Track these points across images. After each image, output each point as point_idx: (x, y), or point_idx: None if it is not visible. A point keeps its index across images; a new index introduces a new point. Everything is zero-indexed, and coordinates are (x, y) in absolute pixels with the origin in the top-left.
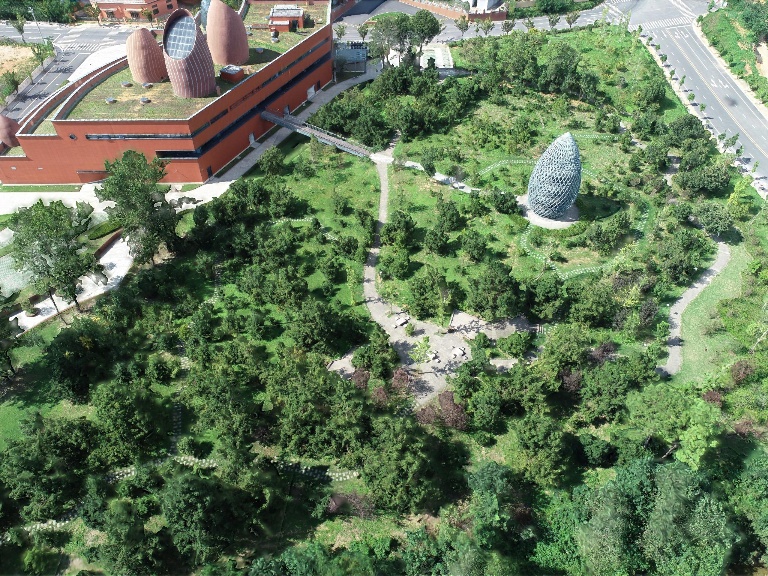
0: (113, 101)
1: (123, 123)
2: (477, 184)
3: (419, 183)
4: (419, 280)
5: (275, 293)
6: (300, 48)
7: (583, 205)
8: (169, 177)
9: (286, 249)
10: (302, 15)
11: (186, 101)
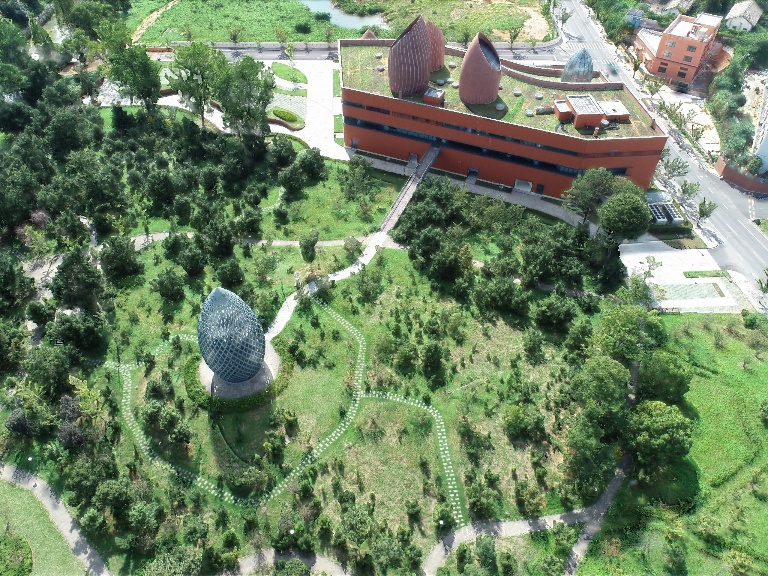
0: (378, 57)
1: None
2: (302, 305)
3: (316, 262)
4: (125, 242)
5: None
6: (519, 130)
7: (241, 404)
8: None
9: (209, 179)
10: (582, 114)
11: (384, 86)
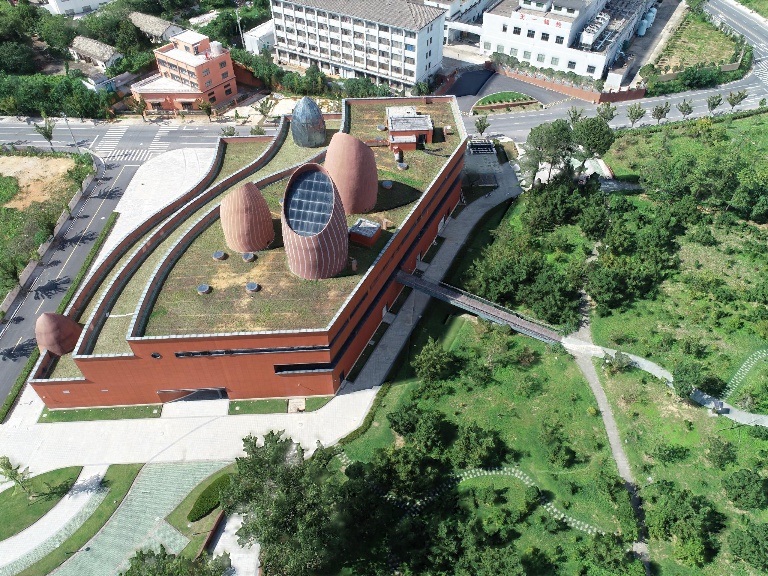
0: (208, 290)
1: (232, 337)
2: None
3: (658, 401)
4: None
5: None
6: (440, 178)
7: None
8: (287, 391)
9: None
10: (432, 127)
11: (311, 285)
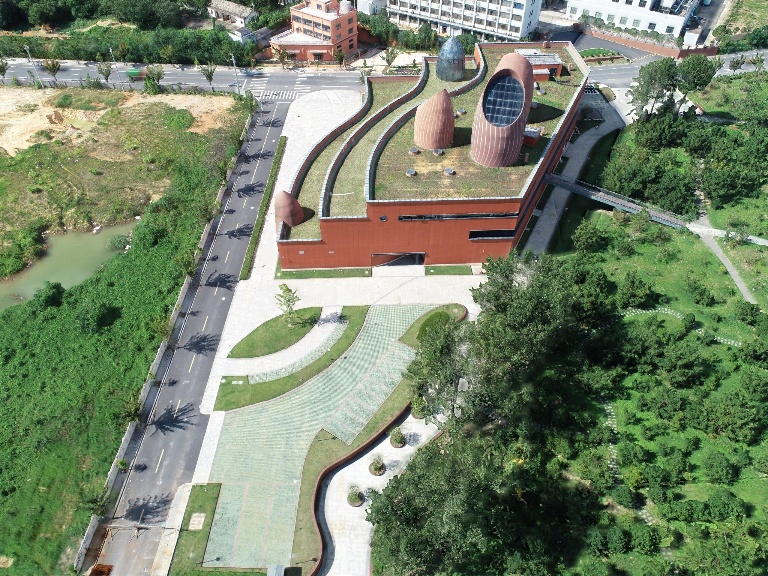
0: (414, 173)
1: (447, 203)
2: None
3: None
4: None
5: (711, 419)
6: None
7: None
8: (472, 258)
9: None
10: None
11: (495, 171)
